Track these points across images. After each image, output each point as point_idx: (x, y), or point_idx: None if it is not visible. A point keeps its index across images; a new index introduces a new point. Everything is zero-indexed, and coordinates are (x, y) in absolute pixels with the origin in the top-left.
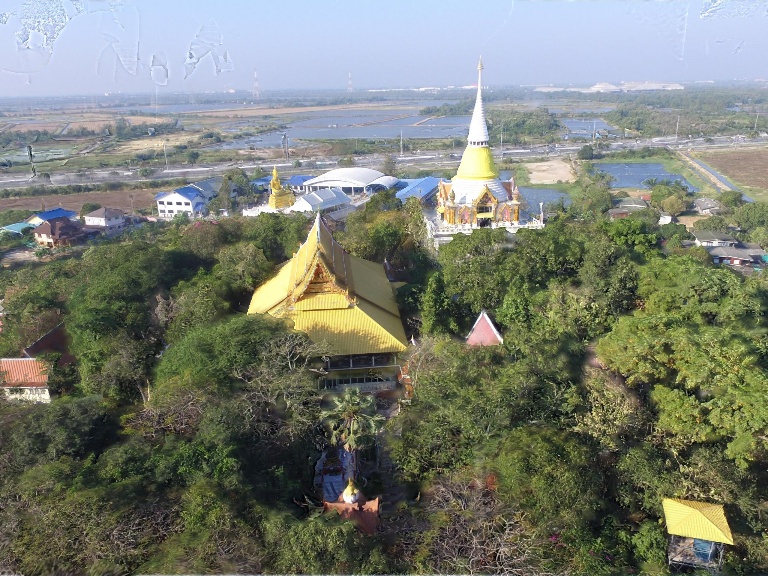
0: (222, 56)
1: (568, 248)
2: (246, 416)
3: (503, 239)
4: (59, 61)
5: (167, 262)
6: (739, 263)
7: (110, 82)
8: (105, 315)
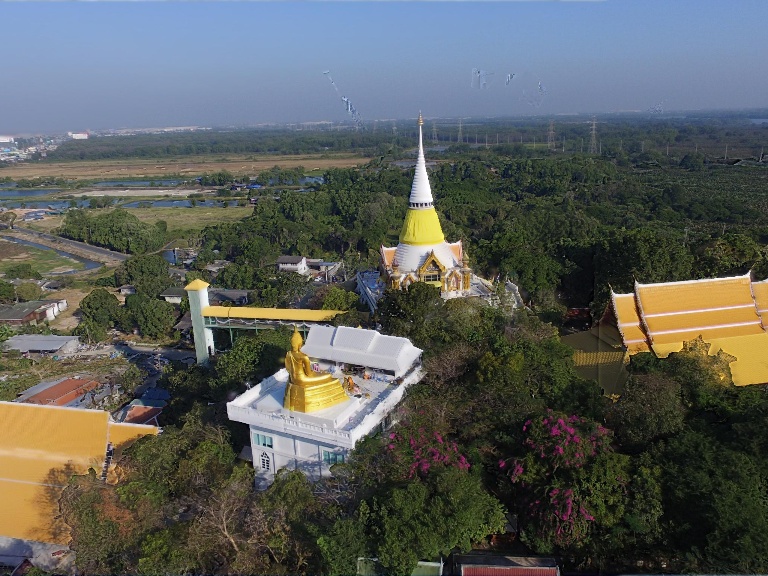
0: None
1: None
2: None
3: None
4: None
5: None
6: None
7: None
8: None
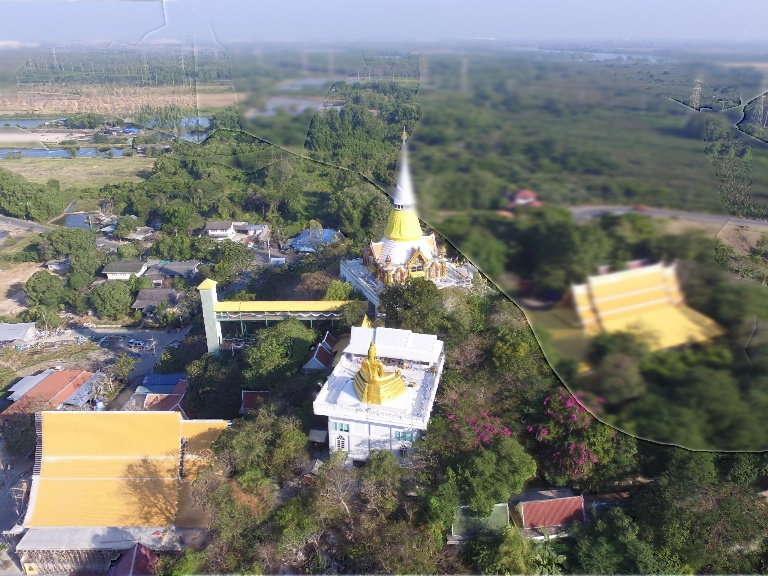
0: None
1: None
2: None
3: None
4: None
5: None
6: None
7: None
8: None
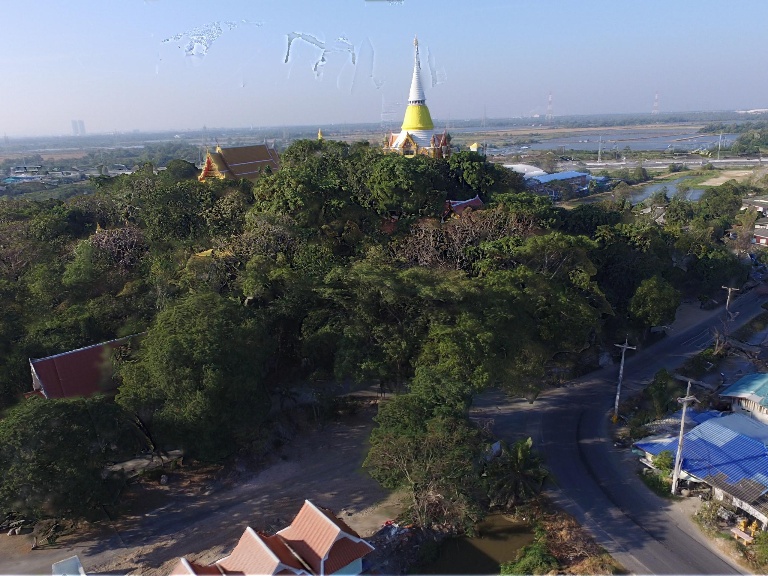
0: (439, 71)
1: (359, 155)
2: (98, 206)
3: (309, 145)
4: (266, 71)
5: (186, 170)
6: (765, 242)
7: (347, 95)
8: (109, 178)
